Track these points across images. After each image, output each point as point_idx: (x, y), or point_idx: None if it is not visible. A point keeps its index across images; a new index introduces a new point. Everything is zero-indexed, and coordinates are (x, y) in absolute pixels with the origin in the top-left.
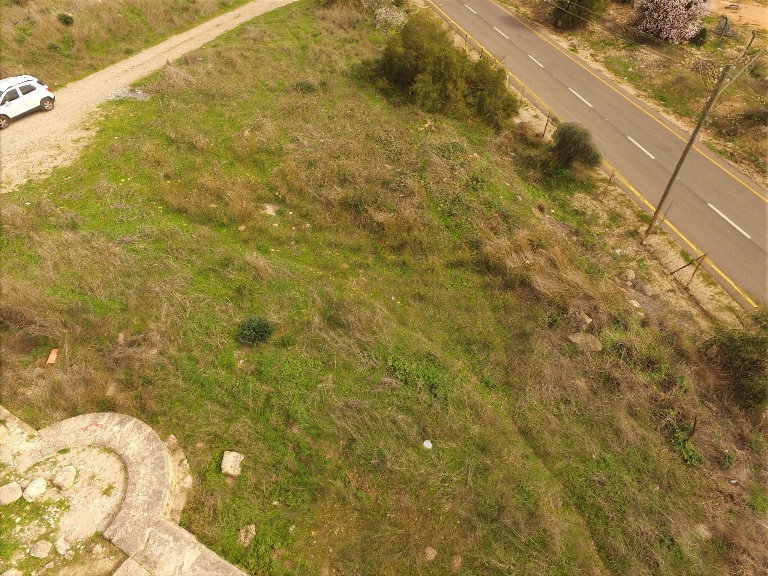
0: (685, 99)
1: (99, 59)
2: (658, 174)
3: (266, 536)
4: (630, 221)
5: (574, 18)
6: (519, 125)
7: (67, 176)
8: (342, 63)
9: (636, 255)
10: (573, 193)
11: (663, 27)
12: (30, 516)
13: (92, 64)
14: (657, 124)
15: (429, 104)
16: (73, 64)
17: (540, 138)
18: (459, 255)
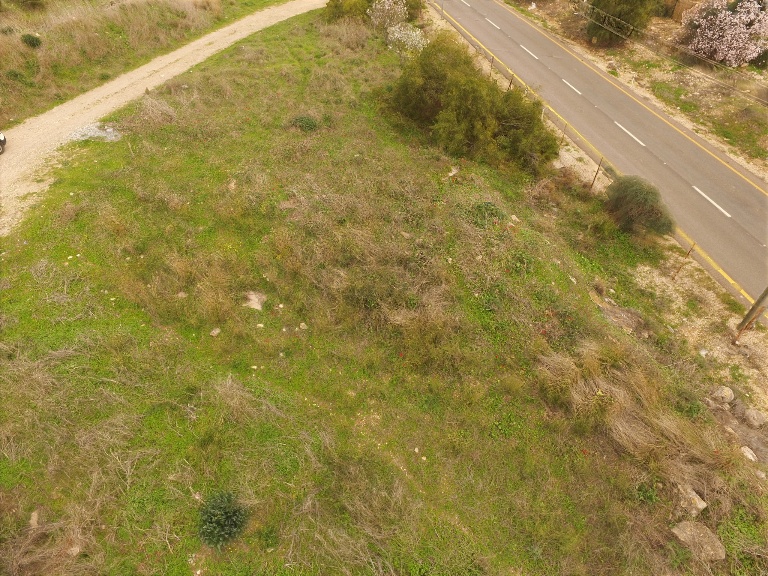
0: (754, 136)
1: (67, 87)
2: (739, 239)
3: None
4: (714, 309)
5: (612, 35)
6: (561, 171)
7: (0, 251)
8: (349, 91)
9: (728, 360)
10: (635, 265)
11: (719, 47)
12: None
13: (58, 94)
14: (726, 169)
15: (453, 147)
16: (36, 94)
17: (588, 189)
18: (505, 381)
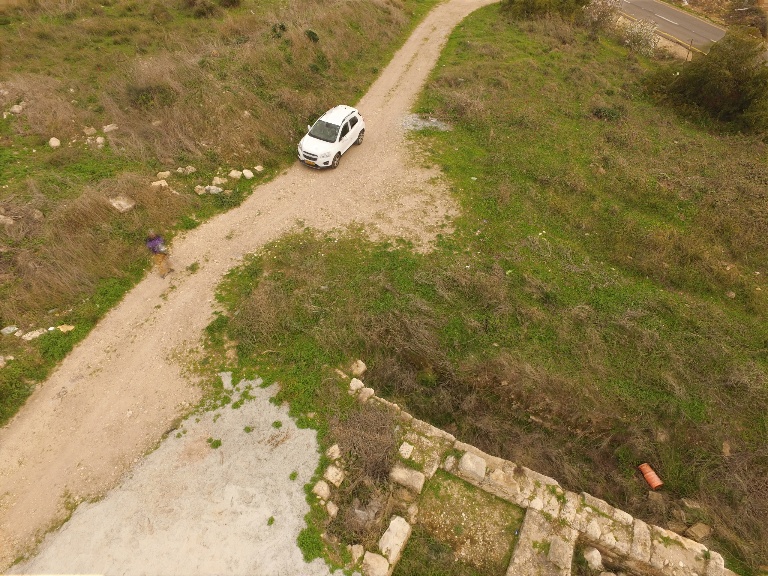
0: None
1: (359, 81)
2: None
3: None
4: None
5: None
6: None
7: (475, 229)
8: (609, 83)
9: None
10: None
11: None
12: None
13: (356, 87)
14: None
15: None
16: (337, 87)
17: None
18: None
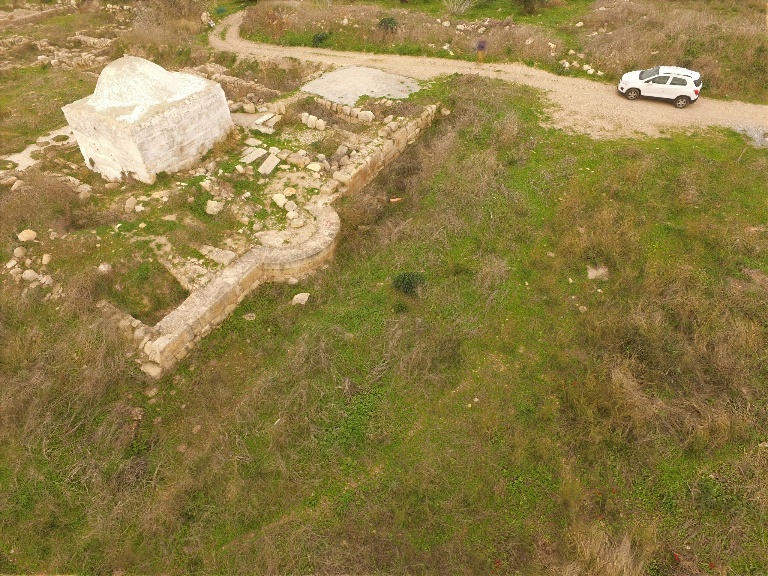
0: None
1: None
2: None
3: (243, 324)
4: None
5: None
6: None
7: (576, 142)
8: None
9: None
10: None
11: None
12: (279, 219)
13: None
14: None
15: None
16: None
17: None
18: None
